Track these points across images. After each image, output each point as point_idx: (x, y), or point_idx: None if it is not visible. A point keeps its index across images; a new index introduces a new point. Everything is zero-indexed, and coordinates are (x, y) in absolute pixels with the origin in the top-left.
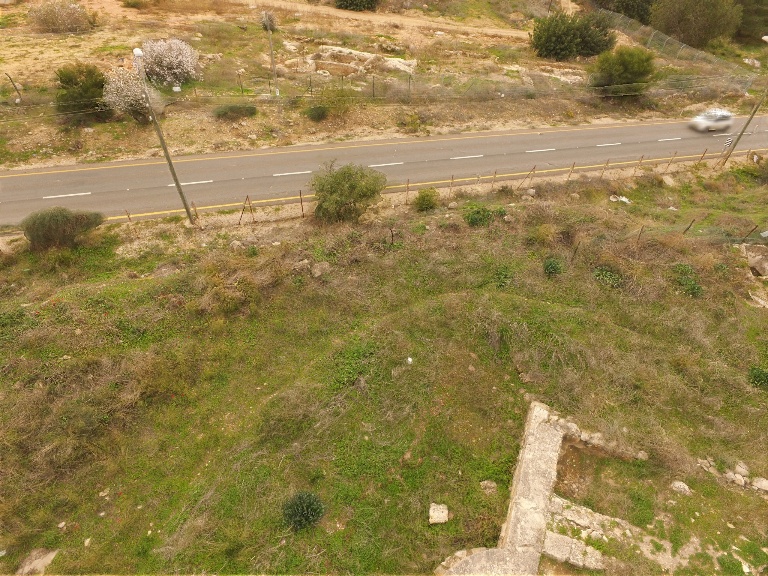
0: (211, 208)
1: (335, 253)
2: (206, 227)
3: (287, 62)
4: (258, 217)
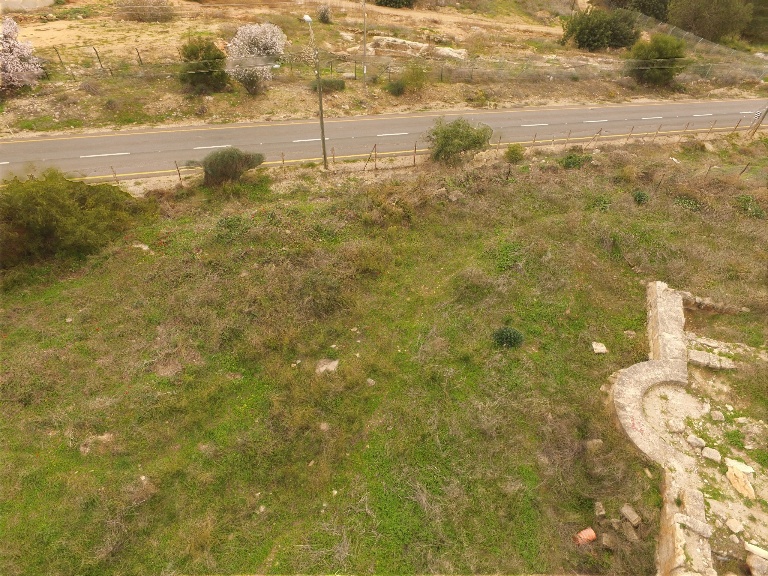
0: (336, 158)
1: (464, 184)
2: (338, 172)
3: (349, 50)
4: (378, 165)
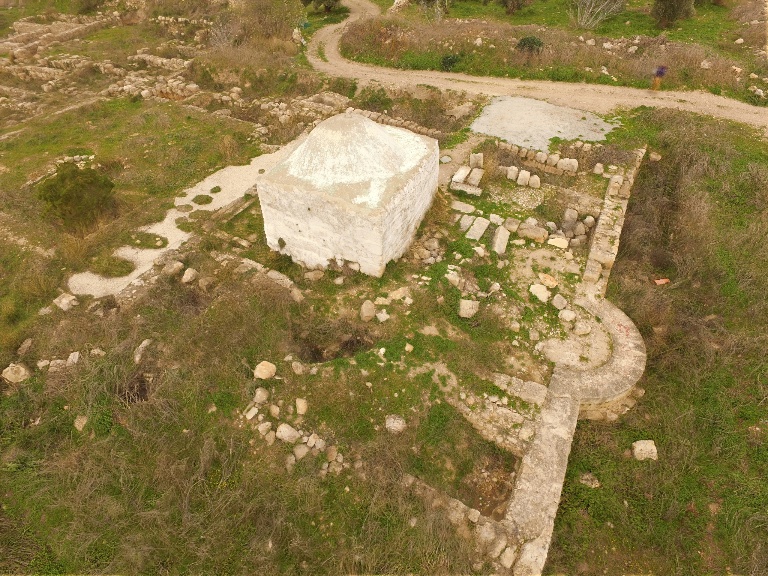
0: None
1: None
2: None
3: None
4: None
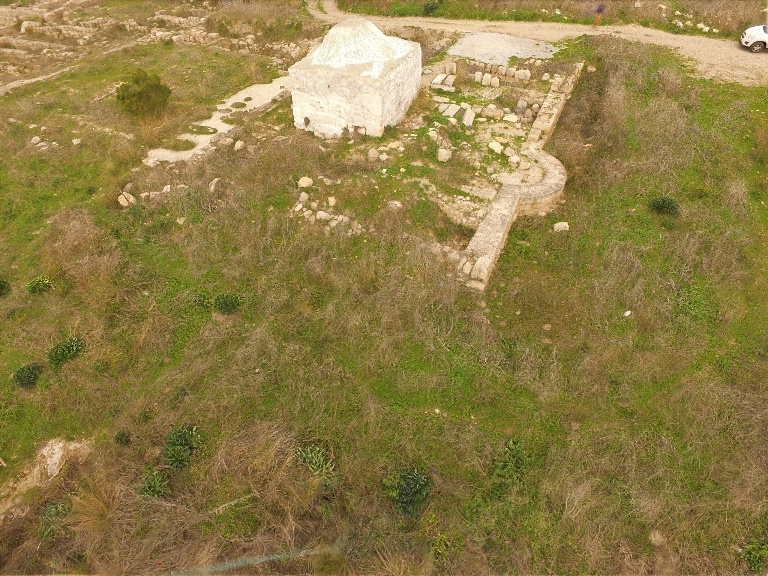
0: None
1: None
2: None
3: None
4: None
